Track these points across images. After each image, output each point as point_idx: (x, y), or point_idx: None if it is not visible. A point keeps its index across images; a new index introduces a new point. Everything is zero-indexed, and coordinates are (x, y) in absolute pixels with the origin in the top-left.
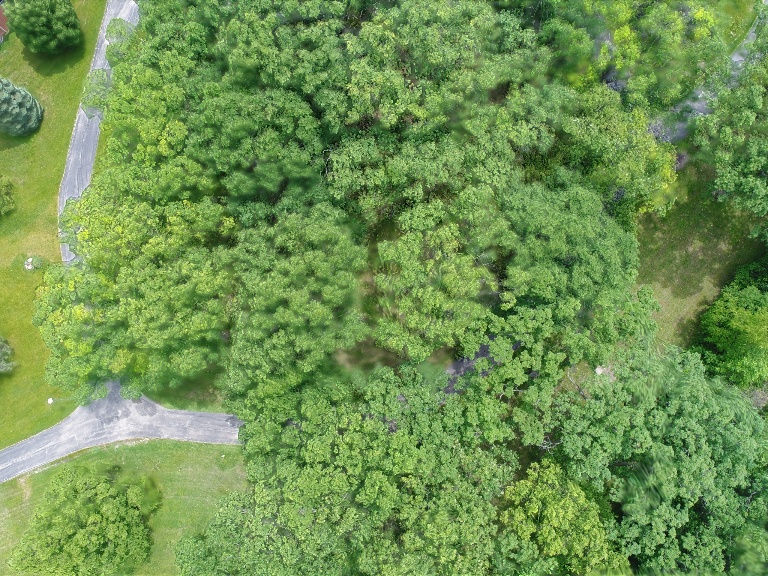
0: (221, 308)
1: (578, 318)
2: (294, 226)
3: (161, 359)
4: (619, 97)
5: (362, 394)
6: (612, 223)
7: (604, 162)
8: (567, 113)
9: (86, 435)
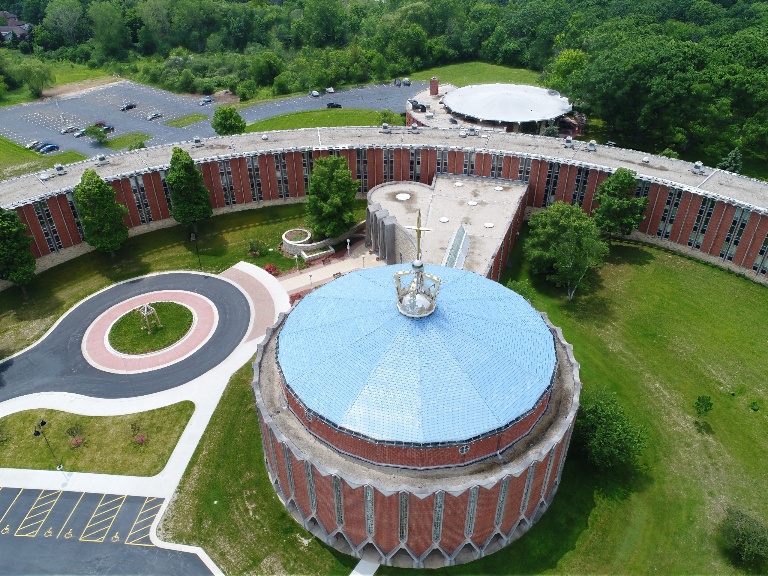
0: None
1: None
2: None
3: None
4: None
5: None
6: None
7: None
8: None
9: None
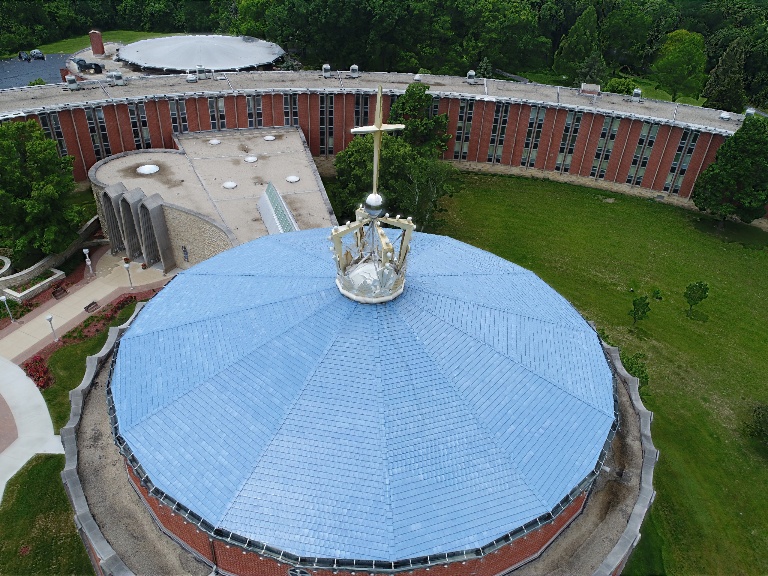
0: None
1: None
2: None
3: None
4: None
5: None
6: None
7: None
8: None
9: None
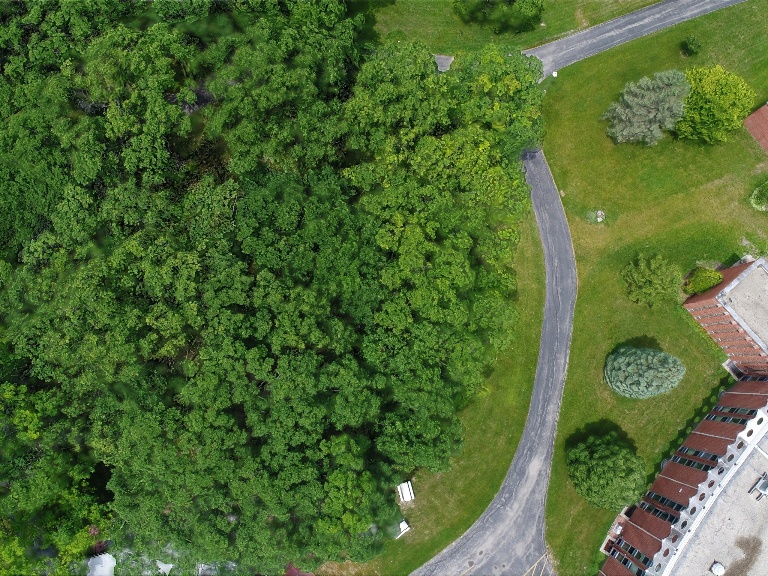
0: None
1: (7, 55)
2: None
3: None
4: None
5: (215, 2)
6: None
7: None
8: None
9: None
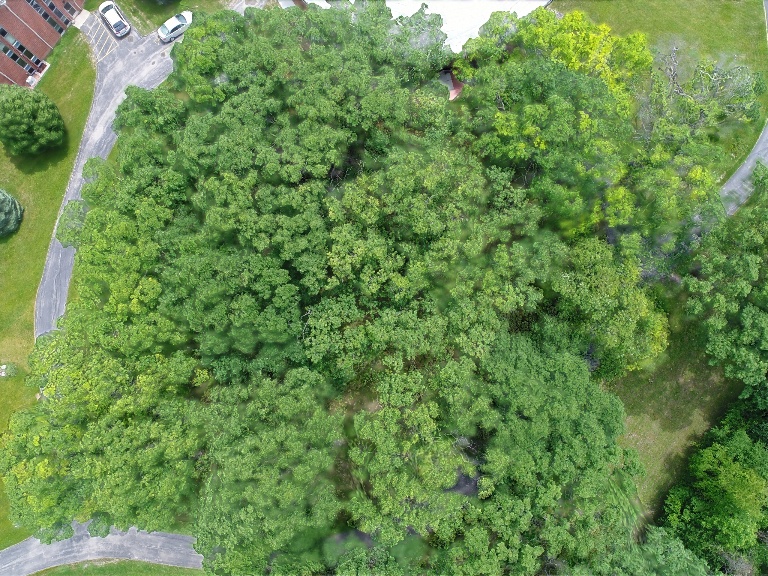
0: (191, 466)
1: (558, 508)
2: (268, 395)
3: (127, 517)
4: (611, 257)
5: (332, 575)
6: (599, 392)
7: (593, 325)
8: (557, 270)
9: (54, 553)
